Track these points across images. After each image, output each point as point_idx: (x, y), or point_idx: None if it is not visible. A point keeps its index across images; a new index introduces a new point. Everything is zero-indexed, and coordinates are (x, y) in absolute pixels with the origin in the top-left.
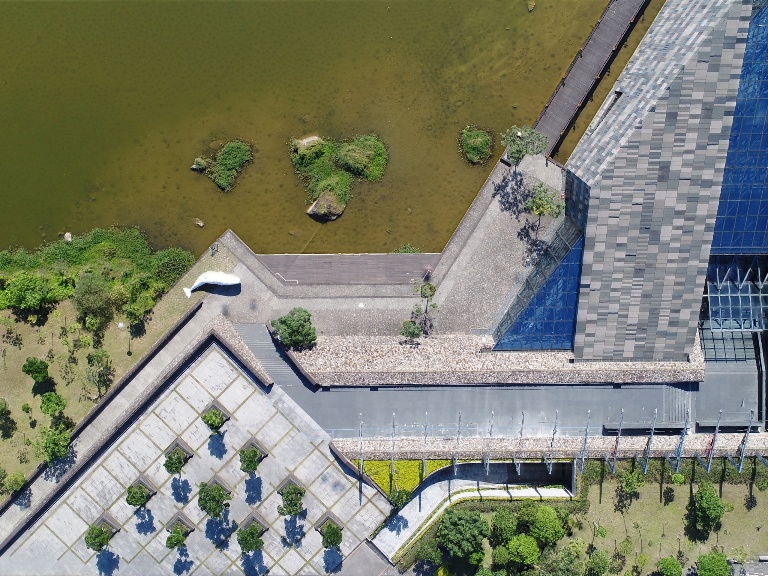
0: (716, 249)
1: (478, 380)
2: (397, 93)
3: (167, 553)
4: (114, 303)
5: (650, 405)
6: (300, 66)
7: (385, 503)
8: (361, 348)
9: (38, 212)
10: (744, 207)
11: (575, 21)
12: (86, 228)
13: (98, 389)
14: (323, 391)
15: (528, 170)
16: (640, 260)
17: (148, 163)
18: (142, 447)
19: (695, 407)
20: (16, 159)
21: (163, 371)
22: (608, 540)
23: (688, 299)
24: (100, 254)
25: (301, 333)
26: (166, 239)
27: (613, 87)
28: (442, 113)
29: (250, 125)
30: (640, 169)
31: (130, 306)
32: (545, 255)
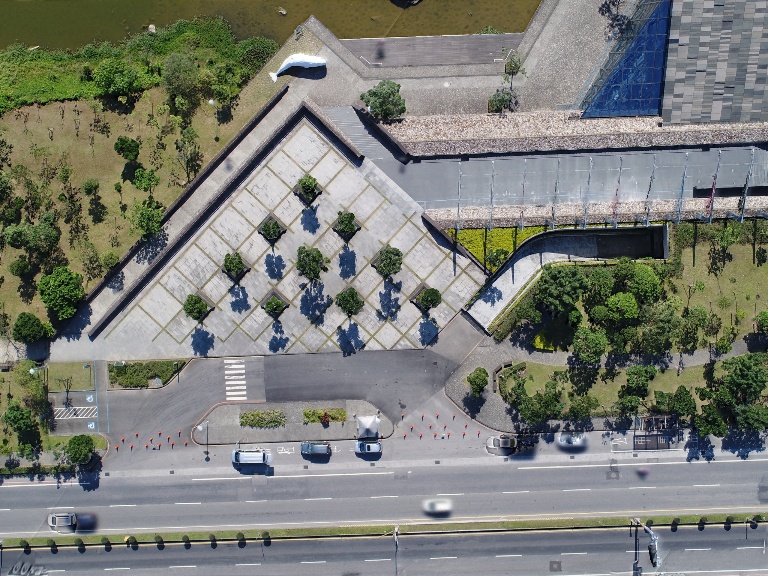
0: None
1: (568, 145)
2: None
3: (262, 331)
4: (200, 90)
5: (739, 167)
6: None
7: (479, 273)
8: (450, 120)
9: (121, 6)
10: None
11: None
12: (169, 20)
13: (187, 174)
14: (414, 163)
15: None
16: (728, 10)
17: None
18: (235, 224)
19: None
20: None
21: (252, 152)
22: (703, 303)
23: None
24: (185, 44)
25: (392, 101)
26: (249, 28)
27: None
28: None
29: None
30: None
31: (219, 86)
32: (627, 29)
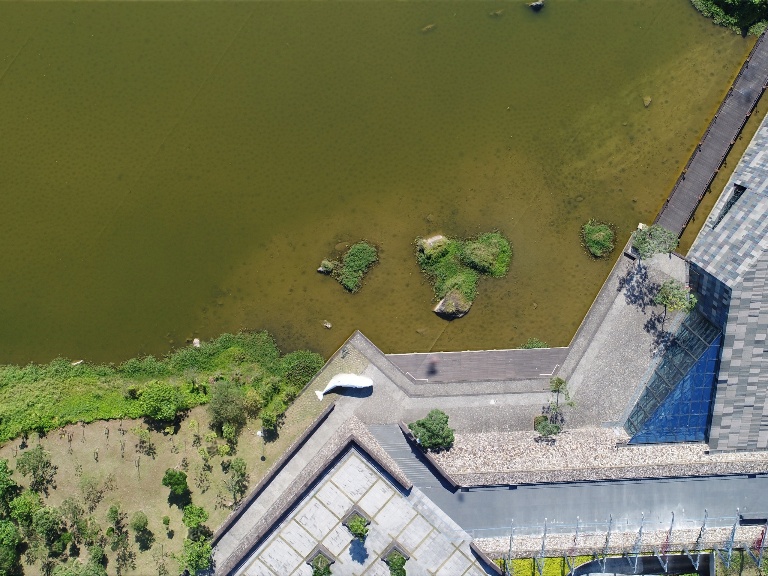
0: None
1: (616, 475)
2: (519, 190)
3: None
4: (246, 408)
5: None
6: (422, 167)
7: None
8: (498, 447)
9: (165, 319)
10: None
11: (690, 115)
12: (214, 333)
13: (233, 496)
14: (462, 491)
15: (652, 263)
16: None
17: (274, 267)
18: (283, 555)
19: None
20: (142, 267)
21: (299, 476)
22: None
23: None
24: (230, 359)
25: (441, 436)
26: (294, 342)
27: (730, 179)
28: (564, 209)
29: (375, 226)
30: None
31: (266, 413)
32: (672, 346)
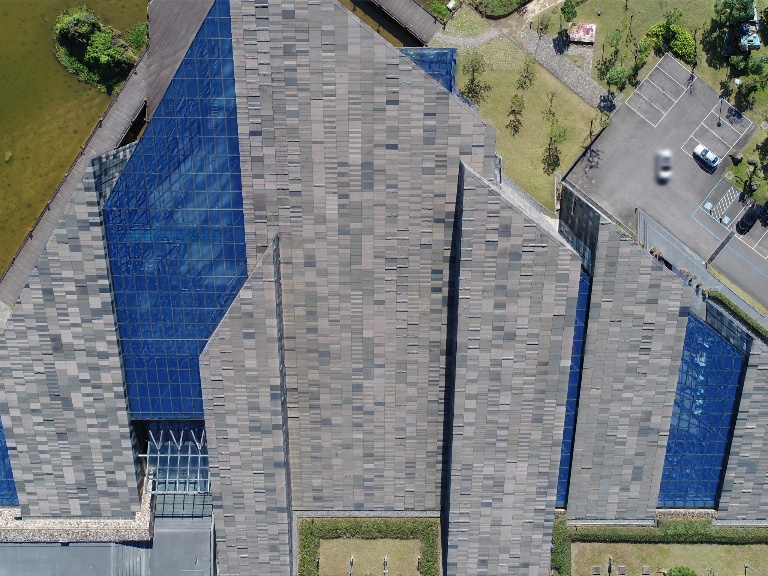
0: (138, 414)
1: None
2: None
3: None
4: None
5: (98, 563)
6: None
7: None
8: None
9: None
10: (153, 375)
11: (52, 172)
12: None
13: None
14: None
15: None
16: (60, 424)
17: None
18: None
19: (149, 564)
20: None
21: None
22: None
23: (119, 461)
24: None
25: None
26: None
27: None
28: None
29: None
30: (32, 341)
31: None
32: None
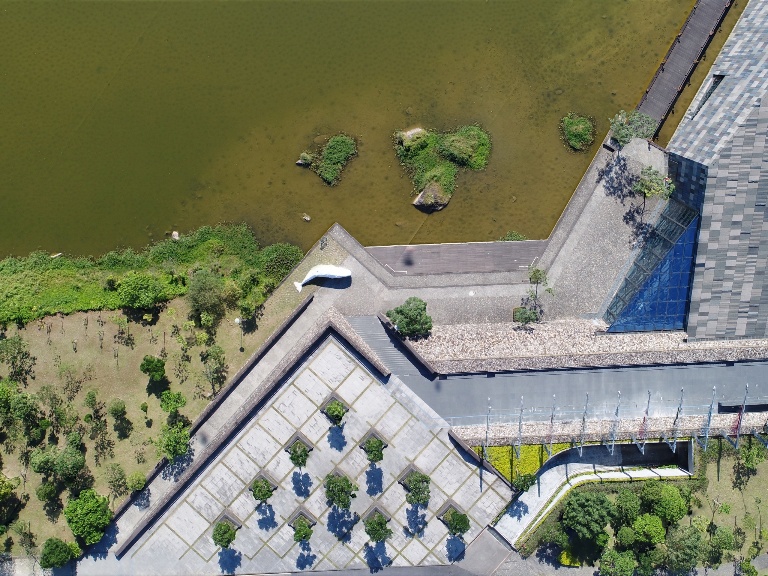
0: None
1: (594, 363)
2: (498, 83)
3: (289, 548)
4: (225, 300)
5: (763, 381)
6: (401, 59)
7: (506, 489)
8: (476, 335)
9: (144, 212)
10: None
11: (670, 8)
12: (193, 226)
13: (212, 386)
14: (440, 379)
15: (631, 155)
16: (754, 237)
17: (253, 160)
18: (261, 442)
19: None
20: (121, 160)
21: (278, 366)
22: (728, 517)
23: None
24: (208, 251)
25: (419, 322)
26: (273, 235)
27: (710, 71)
28: (543, 101)
29: (354, 119)
30: (757, 147)
31: (244, 302)
32: (651, 238)
